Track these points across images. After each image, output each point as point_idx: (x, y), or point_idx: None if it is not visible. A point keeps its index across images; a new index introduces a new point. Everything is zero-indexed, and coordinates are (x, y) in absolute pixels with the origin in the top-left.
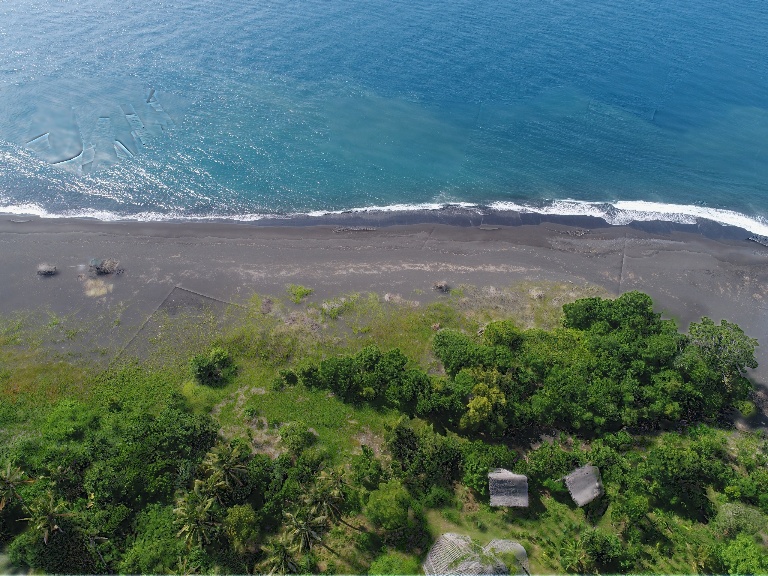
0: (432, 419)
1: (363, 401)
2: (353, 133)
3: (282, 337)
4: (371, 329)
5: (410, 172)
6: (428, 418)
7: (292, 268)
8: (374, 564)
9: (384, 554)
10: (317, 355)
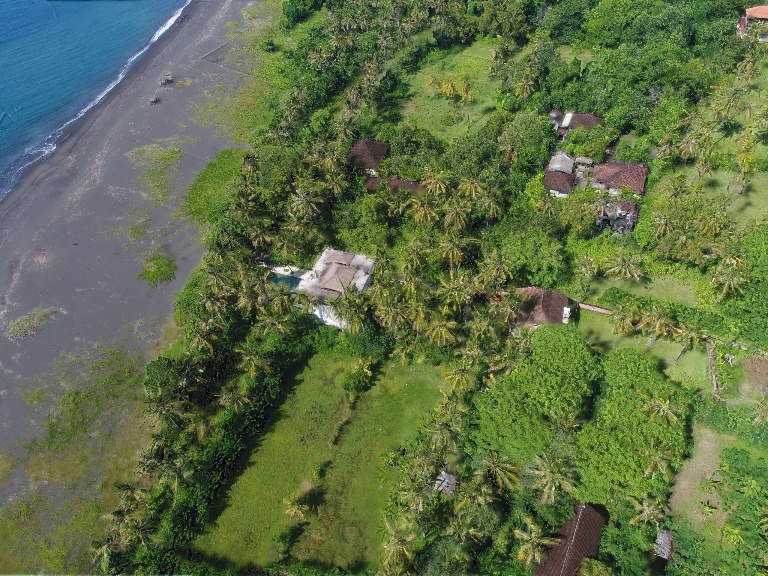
0: (323, 6)
1: (307, 18)
2: (85, 7)
3: (260, 30)
4: (268, 9)
5: (136, 4)
6: (322, 6)
7: (208, 29)
8: (385, 4)
9: (378, 14)
10: (277, 23)
